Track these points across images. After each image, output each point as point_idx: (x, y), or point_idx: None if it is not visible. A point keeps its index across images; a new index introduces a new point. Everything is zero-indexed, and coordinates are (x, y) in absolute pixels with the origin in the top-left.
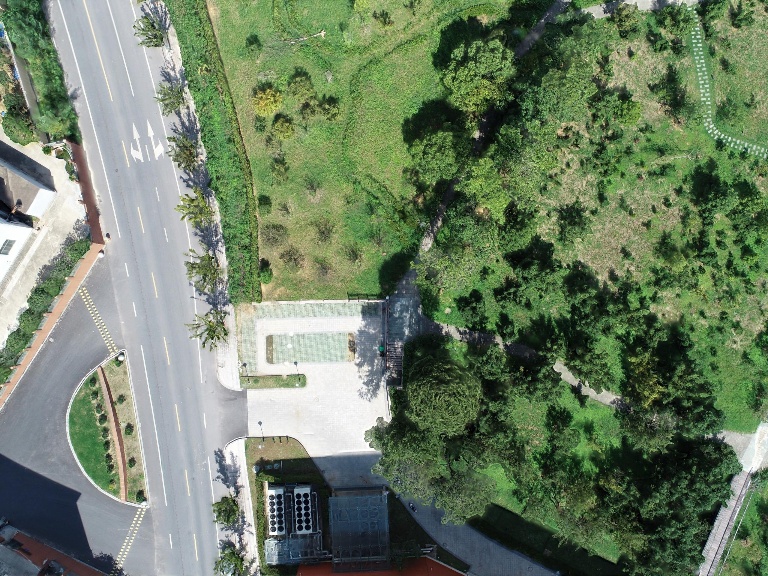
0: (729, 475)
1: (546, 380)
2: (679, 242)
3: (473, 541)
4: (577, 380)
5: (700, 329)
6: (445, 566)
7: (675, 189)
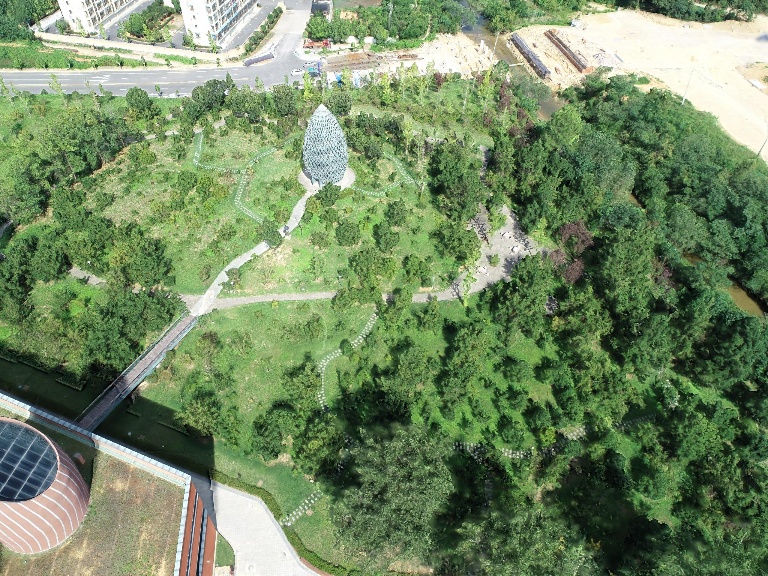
0: None
1: None
2: (168, 205)
3: None
4: (87, 277)
5: (174, 243)
6: None
7: None
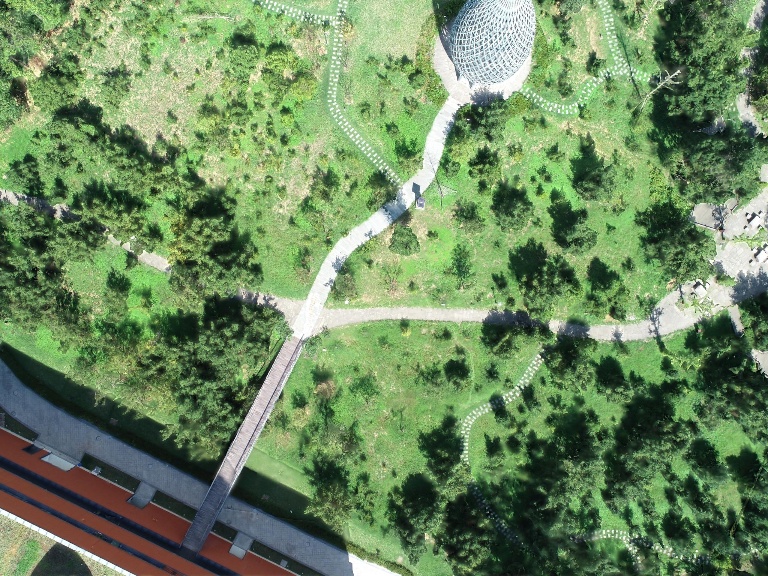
0: (282, 342)
1: (66, 235)
2: (220, 105)
3: (42, 410)
4: None
5: (247, 194)
6: (10, 433)
7: (217, 52)
